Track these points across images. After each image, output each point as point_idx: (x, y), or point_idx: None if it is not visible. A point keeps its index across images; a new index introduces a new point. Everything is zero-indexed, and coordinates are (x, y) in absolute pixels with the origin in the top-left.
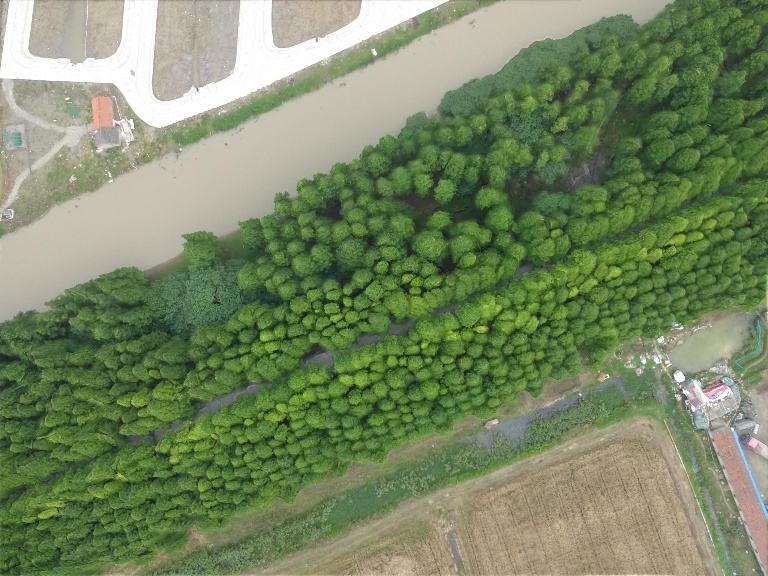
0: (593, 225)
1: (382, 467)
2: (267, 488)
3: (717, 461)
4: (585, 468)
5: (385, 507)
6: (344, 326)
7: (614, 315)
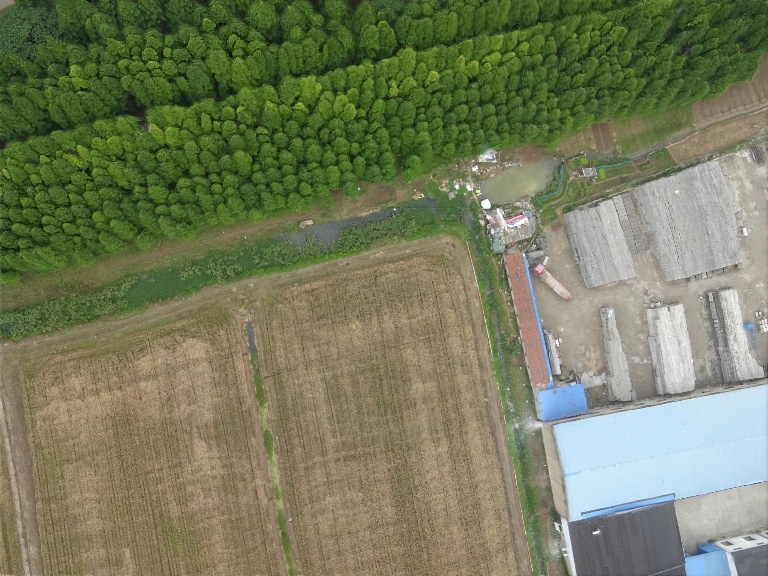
0: (417, 22)
1: (190, 251)
2: (58, 237)
3: (507, 283)
4: (388, 276)
5: (187, 290)
6: (160, 75)
7: (429, 120)
